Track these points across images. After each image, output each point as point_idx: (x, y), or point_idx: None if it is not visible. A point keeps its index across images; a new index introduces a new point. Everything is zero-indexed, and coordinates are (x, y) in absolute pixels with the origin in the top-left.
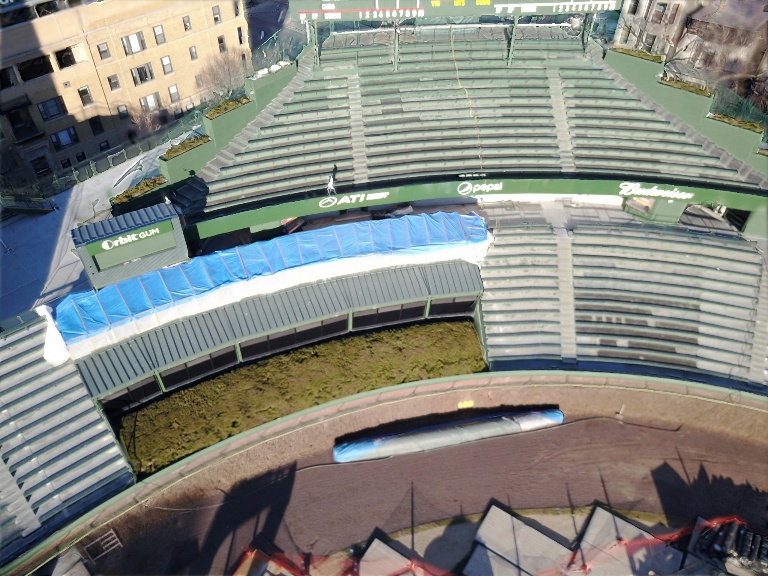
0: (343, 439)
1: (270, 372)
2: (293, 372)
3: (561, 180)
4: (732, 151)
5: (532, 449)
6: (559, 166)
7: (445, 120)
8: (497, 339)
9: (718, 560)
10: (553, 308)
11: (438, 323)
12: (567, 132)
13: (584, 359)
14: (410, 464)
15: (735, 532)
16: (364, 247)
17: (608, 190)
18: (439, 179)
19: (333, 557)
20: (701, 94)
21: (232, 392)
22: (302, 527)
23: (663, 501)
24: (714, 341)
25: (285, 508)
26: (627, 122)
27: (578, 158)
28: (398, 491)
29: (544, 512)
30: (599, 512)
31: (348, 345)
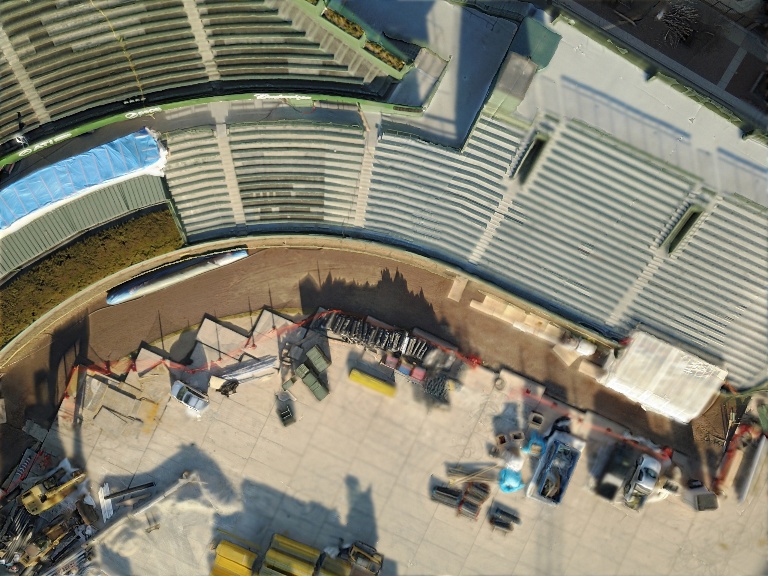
0: (112, 290)
1: (42, 276)
2: (57, 273)
3: (206, 99)
4: (347, 42)
5: (229, 277)
6: (206, 75)
7: (95, 49)
8: (190, 219)
9: (323, 332)
10: (225, 192)
11: (147, 215)
12: (206, 42)
13: (250, 224)
14: (156, 299)
15: (332, 318)
16: (67, 189)
17: (247, 97)
18: (110, 106)
19: (121, 361)
20: (309, 2)
21: (23, 295)
22: (101, 347)
23: (302, 300)
24: (333, 203)
25: (88, 338)
26: (255, 26)
27: (220, 68)
28: (151, 318)
29: (235, 317)
30: (265, 313)
31: (88, 245)
